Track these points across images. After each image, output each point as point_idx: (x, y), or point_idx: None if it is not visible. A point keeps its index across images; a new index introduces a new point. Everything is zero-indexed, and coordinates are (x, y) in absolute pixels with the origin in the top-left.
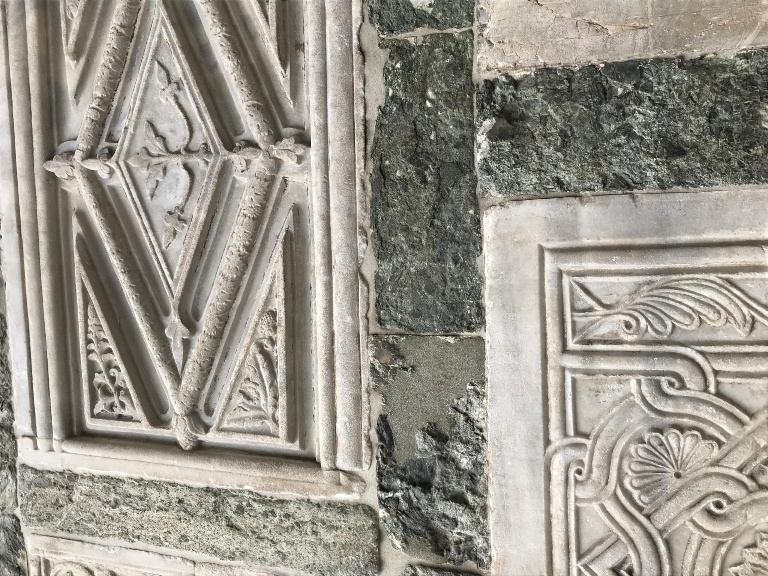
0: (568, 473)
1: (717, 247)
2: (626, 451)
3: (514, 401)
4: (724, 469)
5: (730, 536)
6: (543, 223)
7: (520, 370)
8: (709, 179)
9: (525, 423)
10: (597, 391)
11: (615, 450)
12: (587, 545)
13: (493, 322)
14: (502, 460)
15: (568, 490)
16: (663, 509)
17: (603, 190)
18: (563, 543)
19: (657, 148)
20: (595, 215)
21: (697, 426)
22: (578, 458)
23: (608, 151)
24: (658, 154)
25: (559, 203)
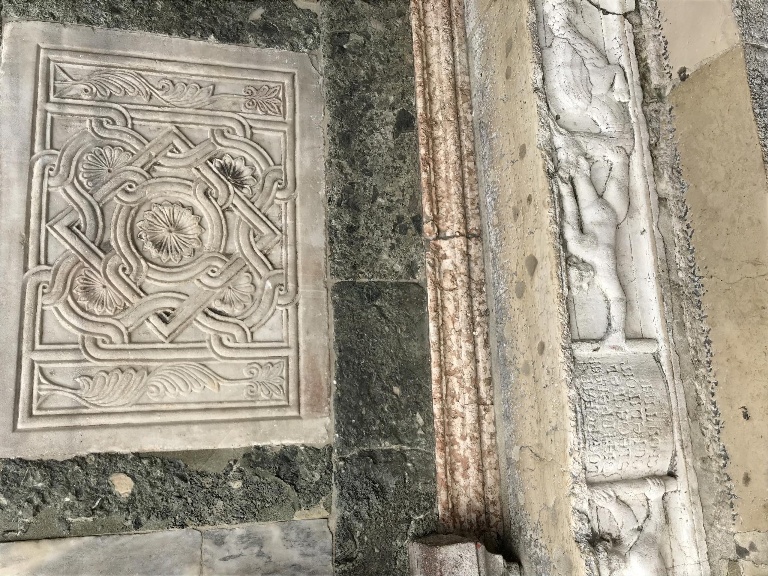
0: (45, 171)
1: (134, 57)
2: (81, 159)
3: (13, 128)
4: (135, 167)
5: (137, 203)
6: (41, 33)
7: (19, 110)
8: (132, 27)
9: (19, 141)
10: (67, 126)
11: (75, 158)
12: (54, 215)
13: (4, 83)
14: (1, 163)
15: (44, 181)
16: (101, 190)
17: (77, 23)
18: (37, 212)
19: (106, 8)
20: (72, 34)
21: (122, 146)
22: (52, 162)
23: (81, 6)
24: (107, 10)
25: (51, 25)
